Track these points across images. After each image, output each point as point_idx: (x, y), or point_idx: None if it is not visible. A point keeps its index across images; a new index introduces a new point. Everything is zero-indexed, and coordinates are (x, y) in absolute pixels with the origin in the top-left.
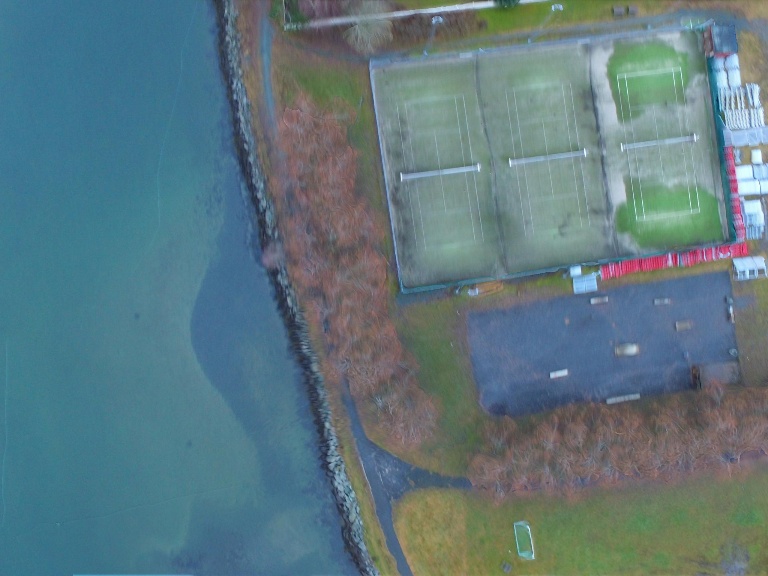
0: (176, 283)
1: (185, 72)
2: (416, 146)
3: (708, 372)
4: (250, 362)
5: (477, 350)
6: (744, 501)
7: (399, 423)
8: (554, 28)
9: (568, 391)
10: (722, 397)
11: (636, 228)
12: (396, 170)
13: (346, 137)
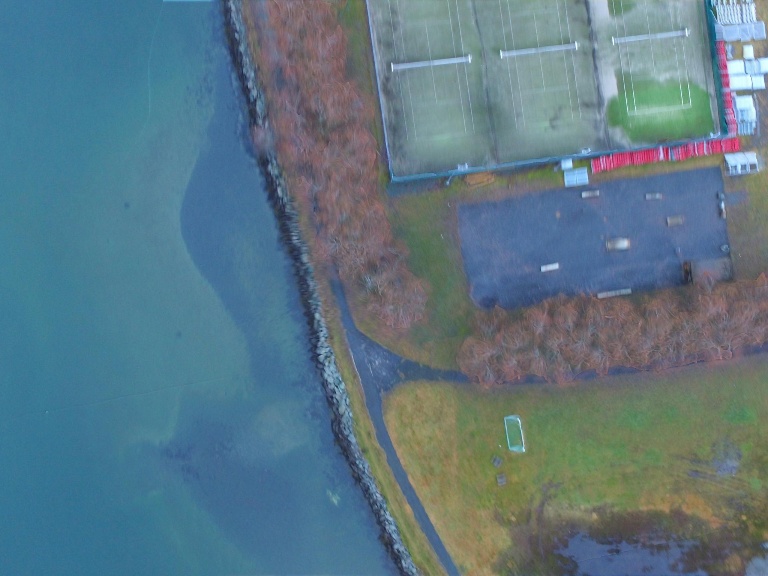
0: (166, 173)
1: None
2: (407, 37)
3: (700, 268)
4: (240, 253)
5: (468, 243)
6: (736, 399)
7: (388, 305)
8: None
9: (559, 285)
10: (713, 286)
11: (627, 122)
12: (387, 60)
13: (336, 20)
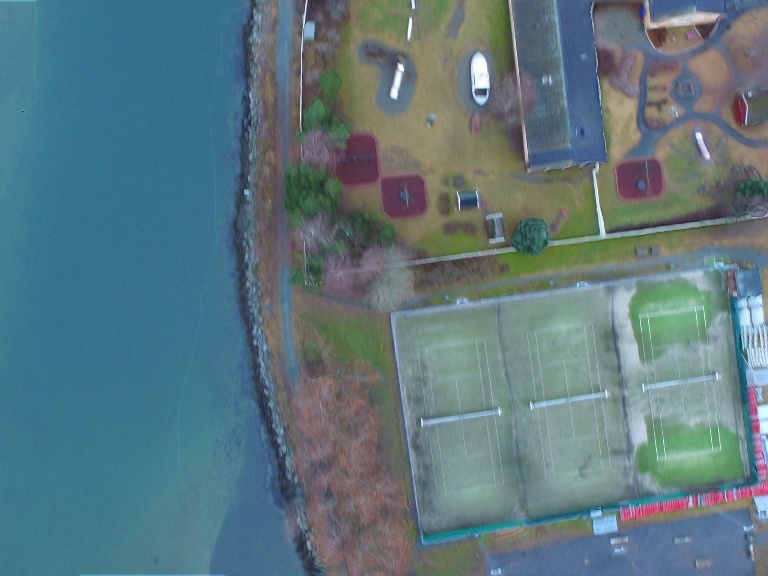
0: (195, 526)
1: (205, 314)
2: (437, 391)
3: None
4: None
5: None
6: None
7: None
8: (576, 269)
9: None
10: None
11: (657, 468)
12: (417, 415)
13: None
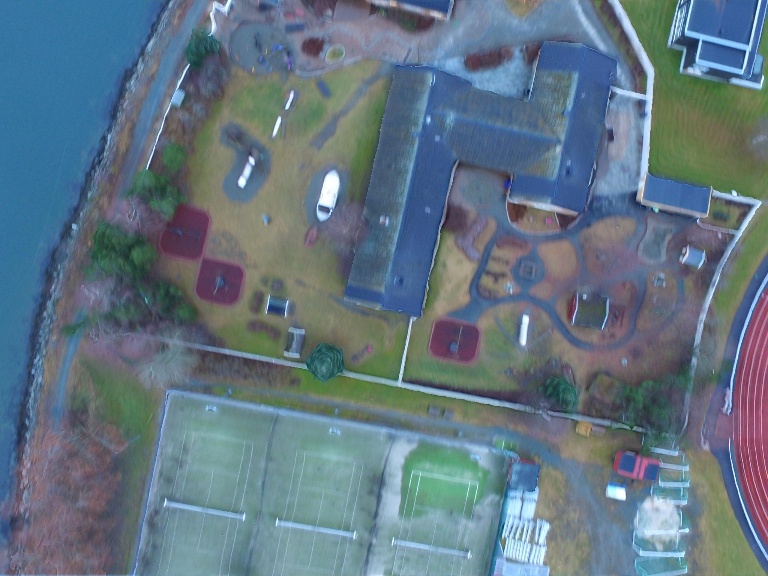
0: None
1: None
2: (190, 477)
3: None
4: None
5: None
6: None
7: None
8: (365, 406)
9: None
10: None
11: None
12: (162, 494)
13: (109, 463)
